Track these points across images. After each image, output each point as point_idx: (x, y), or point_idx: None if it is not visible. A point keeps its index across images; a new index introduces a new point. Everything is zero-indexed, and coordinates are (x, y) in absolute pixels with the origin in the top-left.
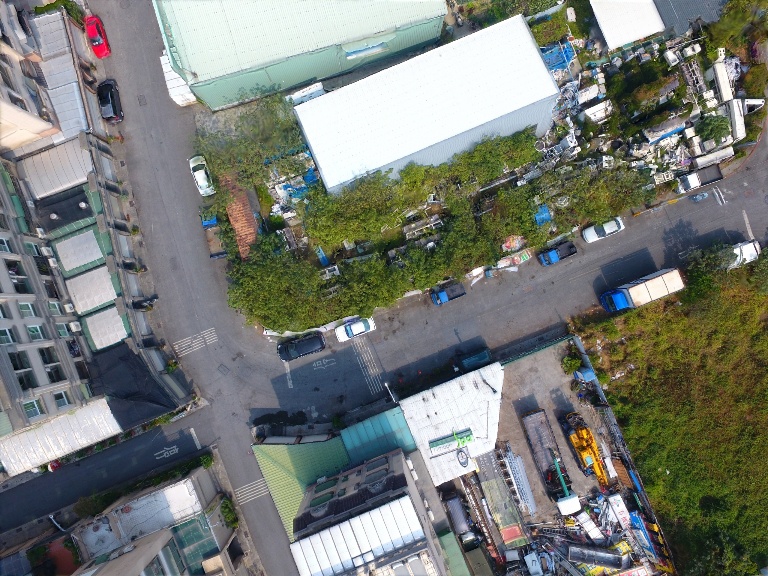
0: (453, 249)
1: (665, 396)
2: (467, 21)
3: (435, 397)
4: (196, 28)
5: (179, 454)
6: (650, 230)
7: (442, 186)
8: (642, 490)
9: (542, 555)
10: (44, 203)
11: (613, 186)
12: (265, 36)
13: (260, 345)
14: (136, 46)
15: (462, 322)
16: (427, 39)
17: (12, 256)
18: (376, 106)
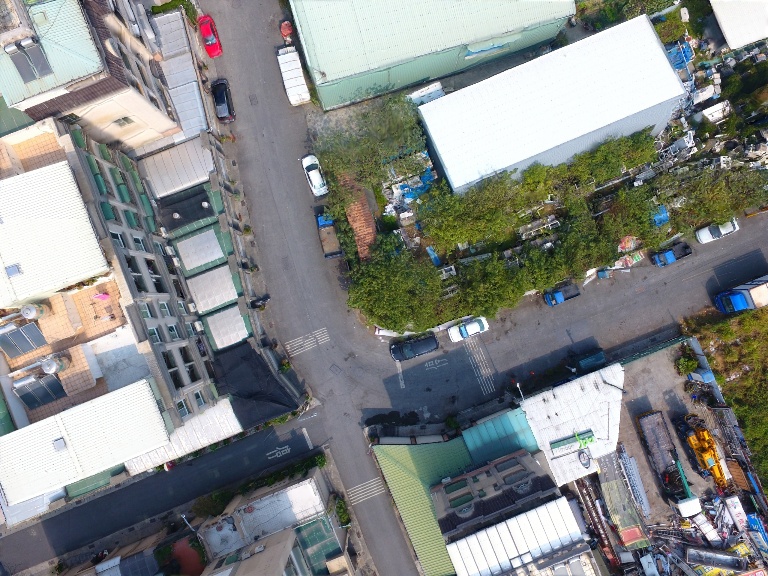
0: (575, 249)
1: None
2: (580, 21)
3: (555, 398)
4: (326, 28)
5: (291, 454)
6: (763, 231)
7: (557, 186)
8: (760, 492)
9: (657, 557)
10: (166, 202)
11: (734, 187)
12: (394, 36)
13: (372, 345)
14: (247, 46)
15: (574, 323)
16: (544, 39)
17: (149, 255)
18: (501, 106)
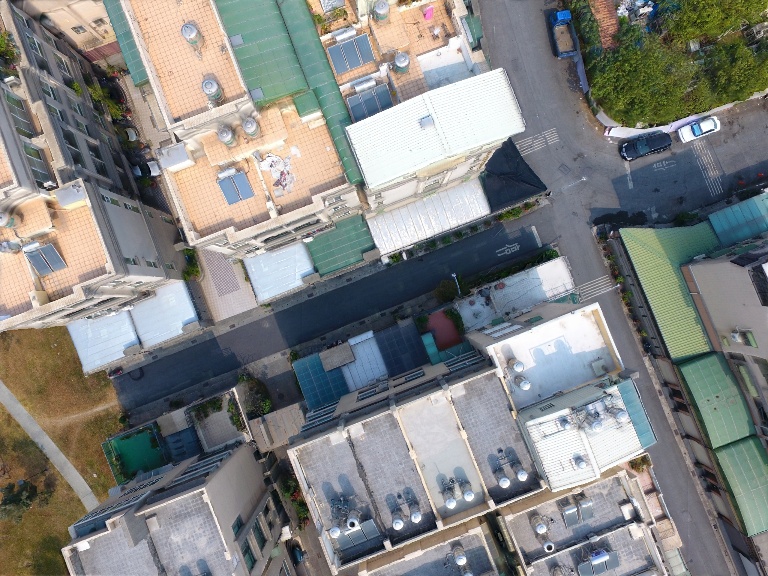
0: None
1: None
2: None
3: None
4: None
5: (520, 251)
6: None
7: None
8: None
9: None
10: None
11: None
12: None
13: (601, 146)
14: None
15: None
16: None
17: None
18: None
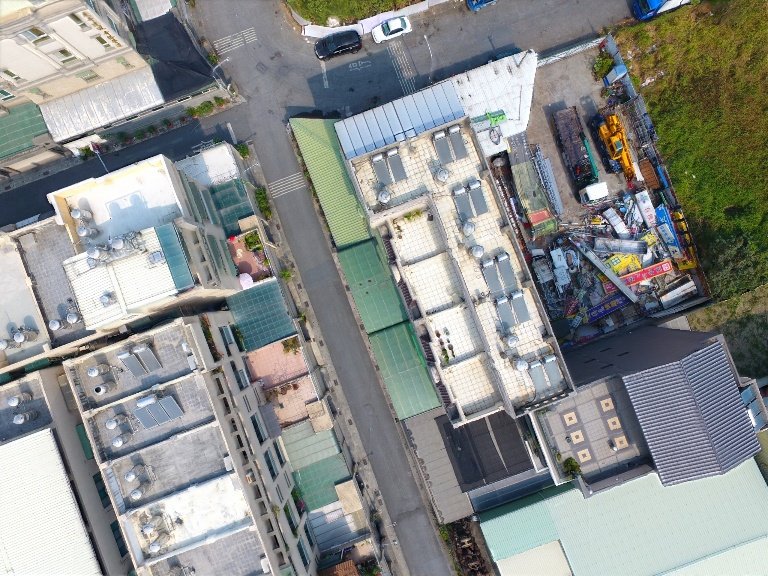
0: None
1: (694, 103)
2: None
3: (469, 80)
4: None
5: None
6: None
7: None
8: (669, 186)
9: (568, 252)
10: None
11: None
12: None
13: (298, 45)
14: None
15: (496, 29)
16: None
17: None
18: None
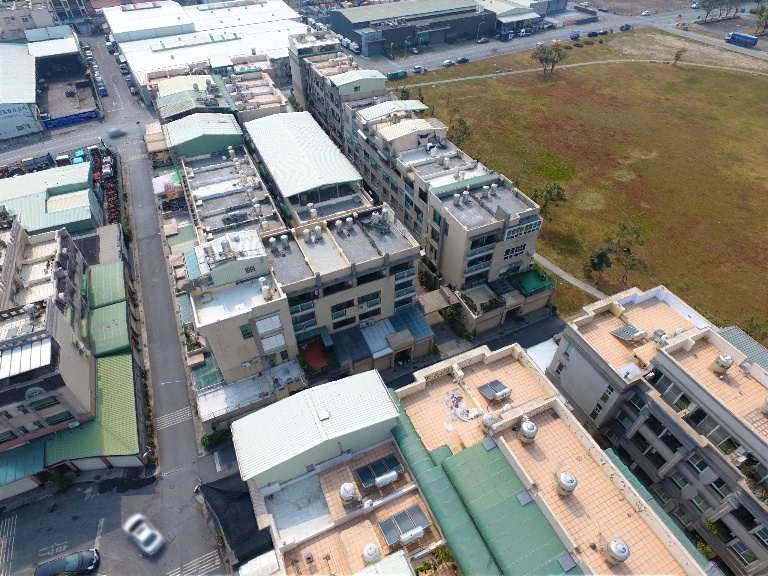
0: None
1: None
2: None
3: None
4: None
5: None
6: None
7: None
8: None
9: None
10: None
11: None
12: None
13: (118, 570)
14: None
15: None
16: None
17: None
18: None
